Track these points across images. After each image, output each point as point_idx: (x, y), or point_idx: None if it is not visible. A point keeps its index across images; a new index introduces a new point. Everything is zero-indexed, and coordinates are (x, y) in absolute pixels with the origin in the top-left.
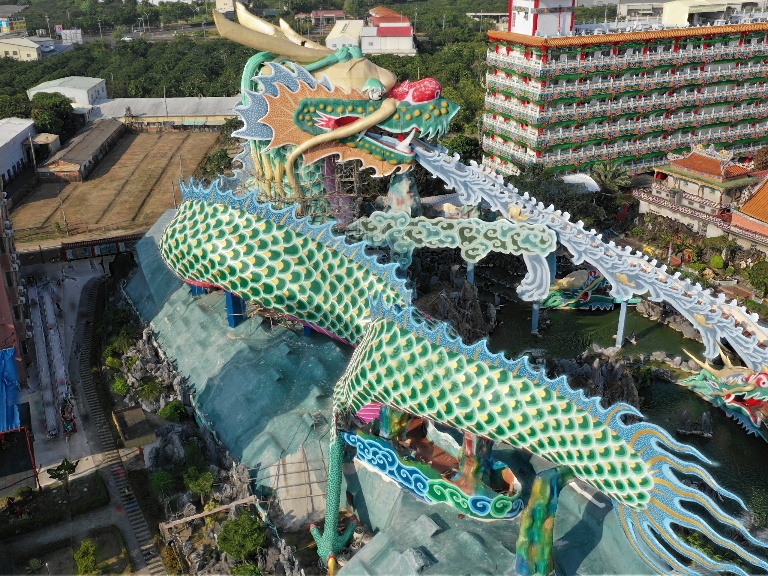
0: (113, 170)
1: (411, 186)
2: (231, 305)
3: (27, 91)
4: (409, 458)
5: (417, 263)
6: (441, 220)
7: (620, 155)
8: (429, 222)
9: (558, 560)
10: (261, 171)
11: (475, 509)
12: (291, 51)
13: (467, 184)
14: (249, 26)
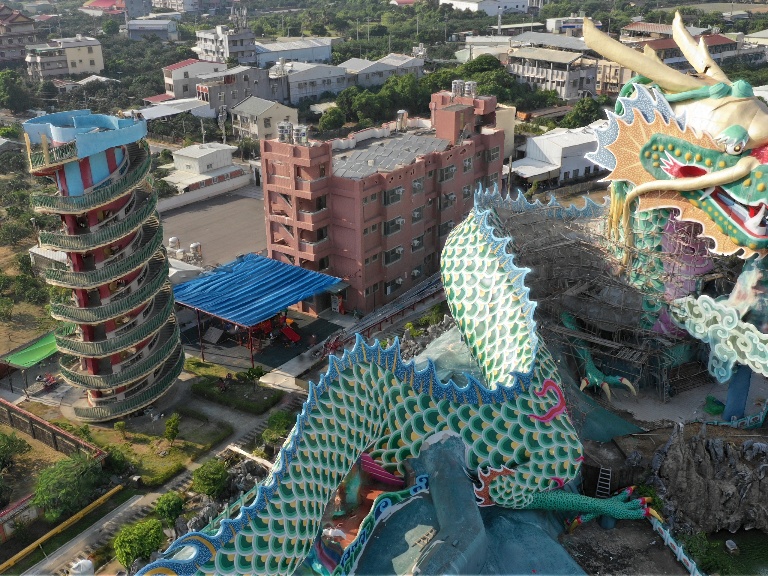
0: None
1: (763, 281)
2: None
3: None
4: None
5: None
6: None
7: None
8: (757, 335)
9: None
10: None
11: None
12: (656, 74)
13: None
14: (677, 41)
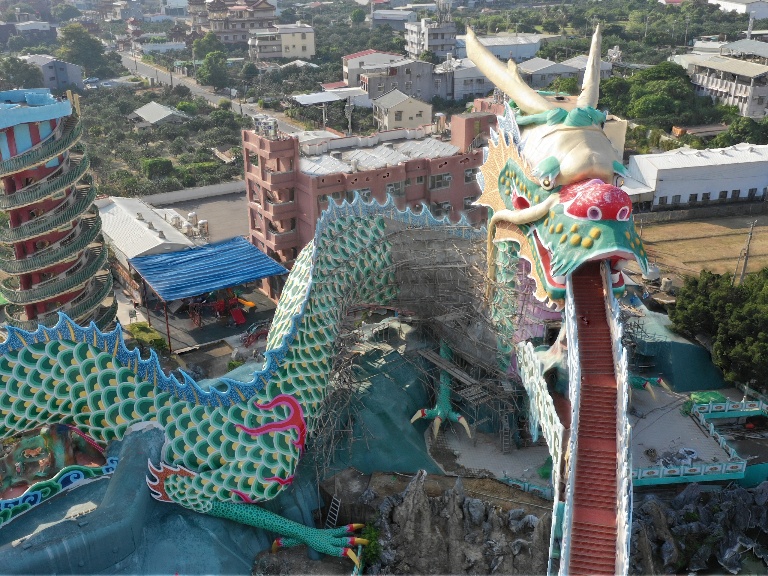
0: None
1: None
2: None
3: None
4: None
5: None
6: None
7: None
8: None
9: None
10: None
11: None
12: (513, 93)
13: None
14: None
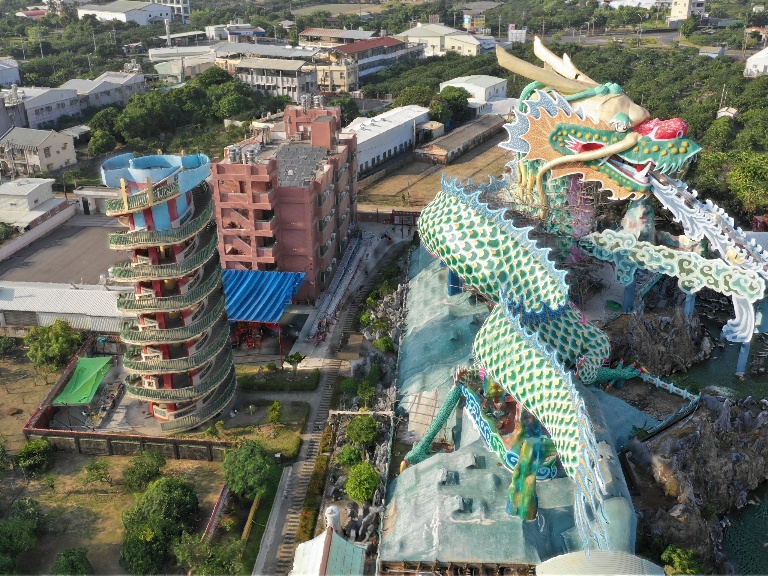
0: (475, 159)
1: (646, 213)
2: (451, 277)
3: (440, 84)
4: (492, 415)
5: (663, 286)
6: (664, 248)
7: None
8: (653, 248)
9: (552, 519)
10: (520, 178)
11: (510, 462)
12: (555, 82)
13: (693, 220)
14: (541, 57)
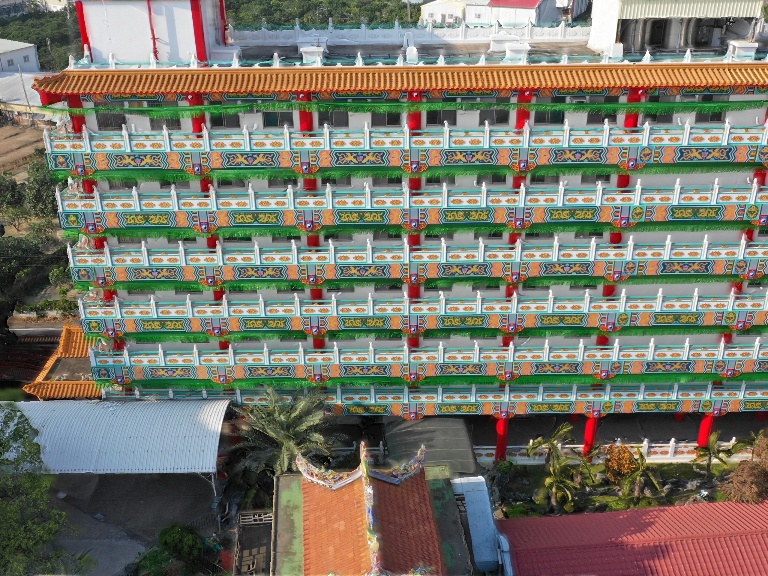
0: None
1: None
2: None
3: None
4: None
5: None
6: None
7: (351, 372)
8: None
9: None
10: None
11: None
12: None
13: None
14: None
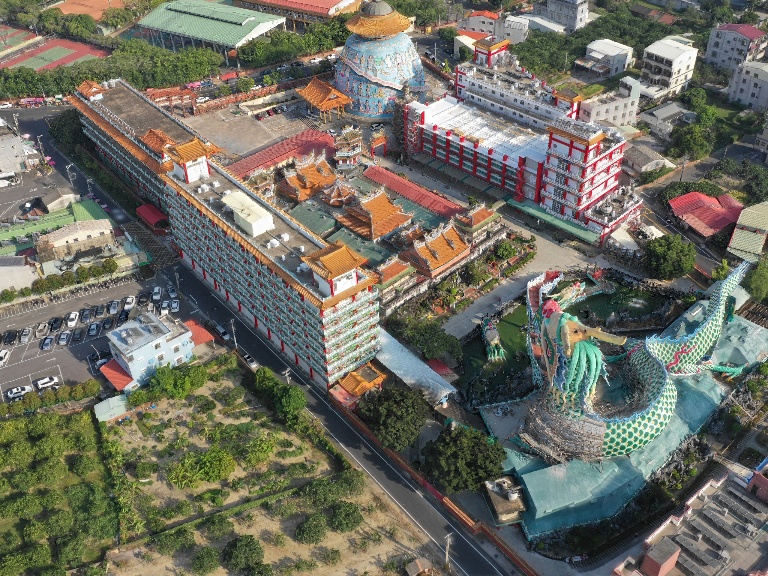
0: None
1: None
2: None
3: None
4: None
5: None
6: None
7: None
8: None
9: None
10: None
11: None
12: None
13: None
14: None
